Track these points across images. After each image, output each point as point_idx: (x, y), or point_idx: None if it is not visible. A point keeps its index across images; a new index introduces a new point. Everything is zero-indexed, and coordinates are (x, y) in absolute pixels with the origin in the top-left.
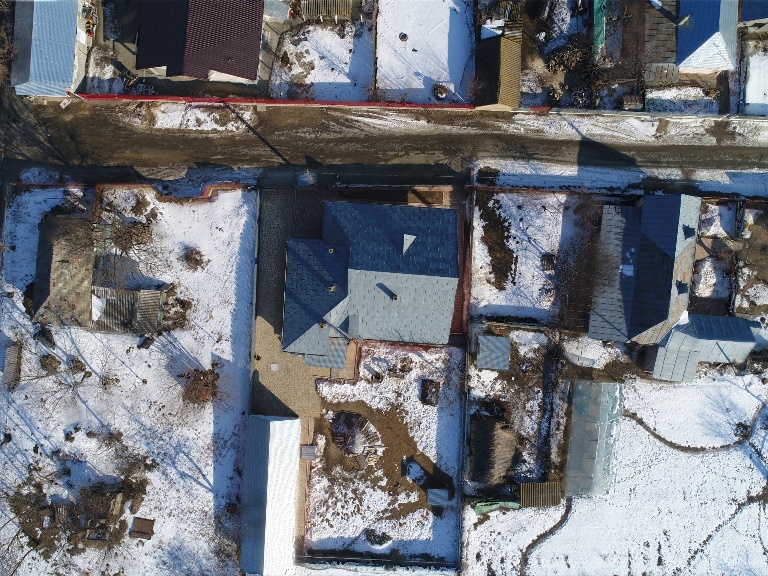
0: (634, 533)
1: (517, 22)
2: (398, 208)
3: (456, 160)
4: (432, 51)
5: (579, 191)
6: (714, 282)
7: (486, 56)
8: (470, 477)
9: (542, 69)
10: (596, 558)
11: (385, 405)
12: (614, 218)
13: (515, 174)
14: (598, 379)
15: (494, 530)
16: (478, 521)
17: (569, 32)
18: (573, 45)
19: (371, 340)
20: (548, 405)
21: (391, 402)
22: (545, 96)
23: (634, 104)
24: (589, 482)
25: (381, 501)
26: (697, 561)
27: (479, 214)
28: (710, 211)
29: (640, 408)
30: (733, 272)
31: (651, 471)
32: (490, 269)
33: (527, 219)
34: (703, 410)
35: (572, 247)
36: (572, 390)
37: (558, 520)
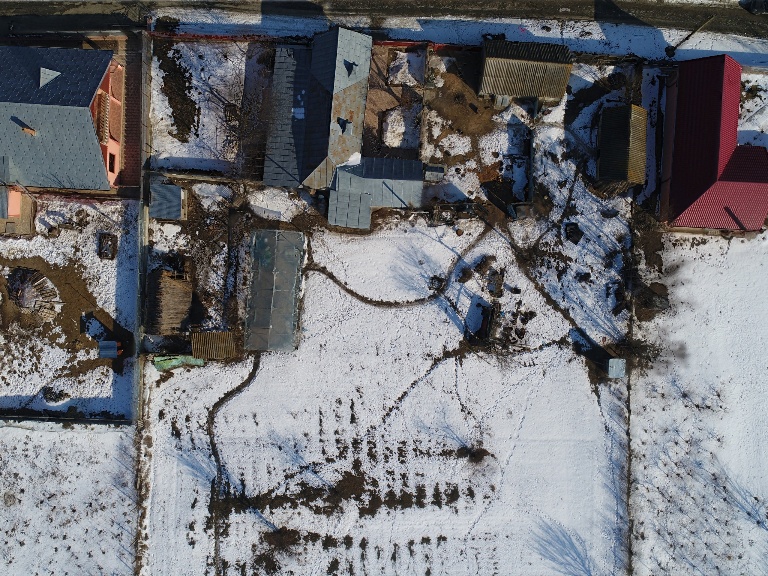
0: (325, 390)
1: None
2: (54, 50)
3: (134, 9)
4: None
5: (263, 40)
6: (403, 131)
7: None
8: (144, 330)
9: None
10: (285, 416)
11: (63, 260)
12: (286, 61)
13: (196, 23)
14: (285, 232)
15: (178, 388)
16: (161, 378)
17: None
18: None
19: (33, 187)
20: (233, 259)
21: (69, 257)
22: None
23: None
24: (278, 338)
25: (59, 358)
26: (392, 419)
27: (158, 64)
28: (399, 58)
29: (329, 261)
30: (425, 121)
31: (342, 326)
32: (172, 121)
33: (208, 69)
34: (395, 263)
35: (256, 97)
36: (258, 243)
37: (246, 377)
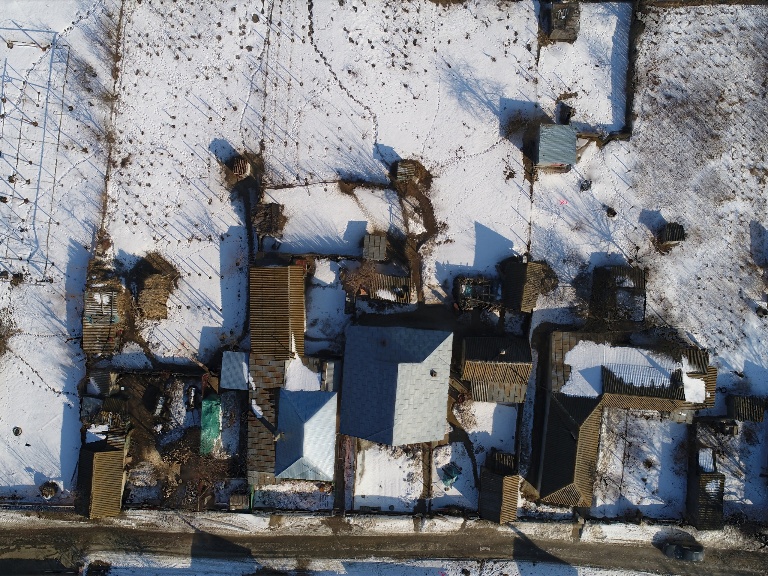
0: None
1: (120, 428)
2: None
3: (67, 554)
4: (45, 446)
5: None
6: None
7: (84, 466)
8: None
9: (158, 461)
10: None
11: None
12: None
13: (127, 567)
14: None
15: None
16: None
17: (186, 425)
18: (185, 442)
19: None
20: None
21: None
22: (160, 489)
23: (240, 505)
24: None
25: None
26: None
27: None
28: None
29: None
30: None
31: None
32: None
33: None
34: None
35: None
36: None
37: None
